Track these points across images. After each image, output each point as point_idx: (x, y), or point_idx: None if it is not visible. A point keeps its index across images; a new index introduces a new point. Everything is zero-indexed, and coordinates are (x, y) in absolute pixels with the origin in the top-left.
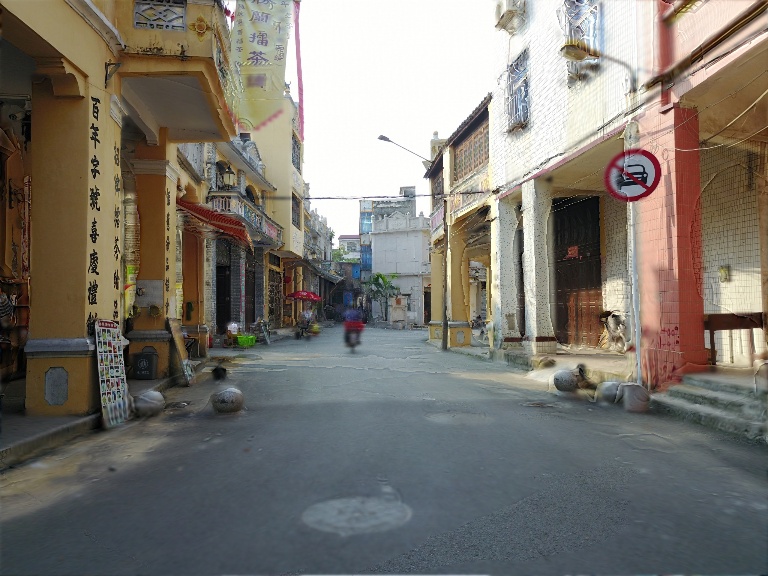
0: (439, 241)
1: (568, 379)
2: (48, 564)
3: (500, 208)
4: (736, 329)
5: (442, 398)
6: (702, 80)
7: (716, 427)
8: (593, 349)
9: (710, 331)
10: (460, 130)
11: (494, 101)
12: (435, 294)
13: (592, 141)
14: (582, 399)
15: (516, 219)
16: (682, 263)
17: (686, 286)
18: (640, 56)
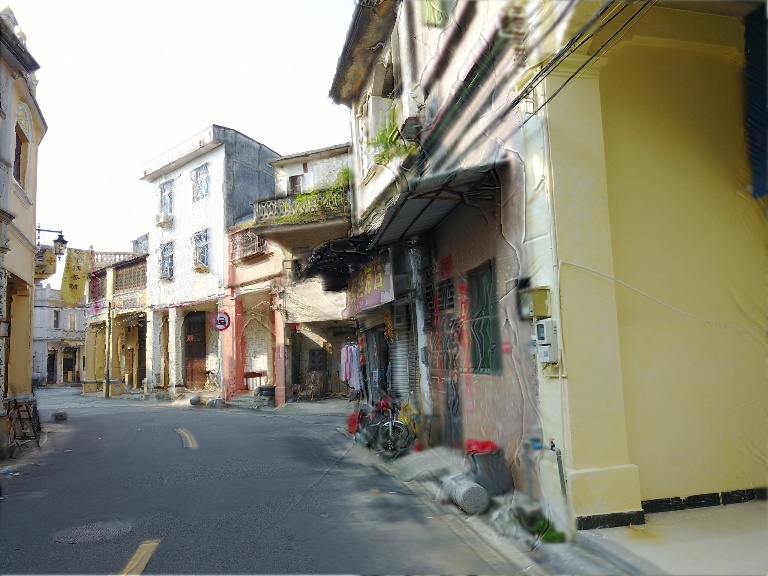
0: (97, 325)
1: (195, 400)
2: (106, 431)
3: (154, 316)
4: (255, 377)
5: (147, 410)
6: (243, 294)
7: (243, 407)
8: (202, 390)
9: (246, 378)
10: (124, 262)
11: (151, 257)
12: (89, 360)
13: (205, 300)
14: (201, 407)
15: (162, 322)
16: (237, 354)
17: (238, 363)
18: (224, 275)
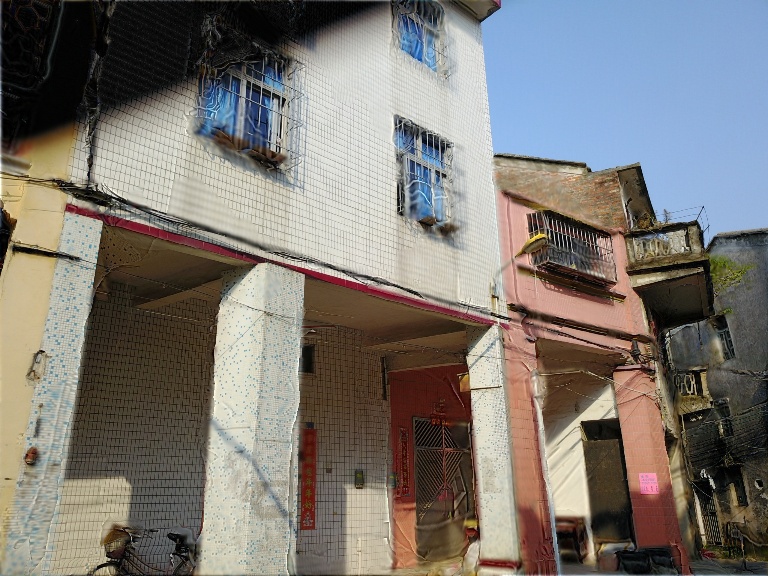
0: None
1: None
2: None
3: (107, 246)
4: None
5: None
6: (552, 338)
7: None
8: None
9: None
10: None
11: (117, 1)
12: None
13: (451, 309)
14: None
15: None
16: None
17: None
18: (505, 276)
